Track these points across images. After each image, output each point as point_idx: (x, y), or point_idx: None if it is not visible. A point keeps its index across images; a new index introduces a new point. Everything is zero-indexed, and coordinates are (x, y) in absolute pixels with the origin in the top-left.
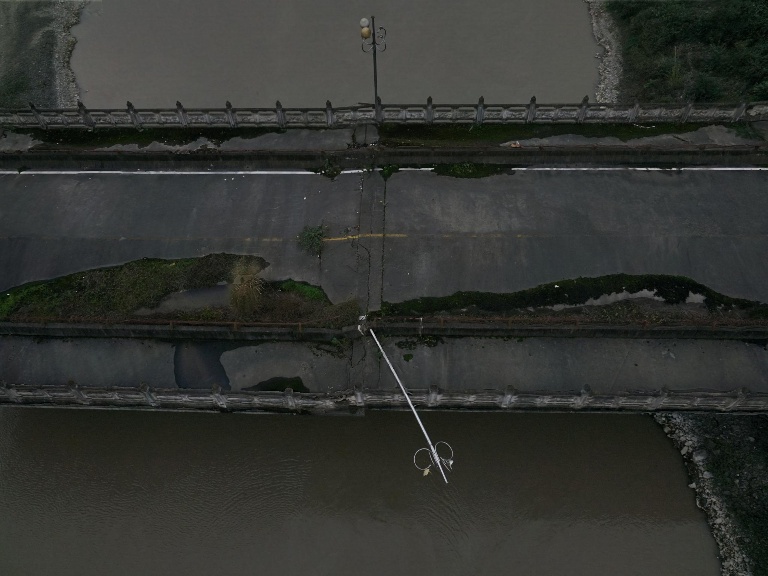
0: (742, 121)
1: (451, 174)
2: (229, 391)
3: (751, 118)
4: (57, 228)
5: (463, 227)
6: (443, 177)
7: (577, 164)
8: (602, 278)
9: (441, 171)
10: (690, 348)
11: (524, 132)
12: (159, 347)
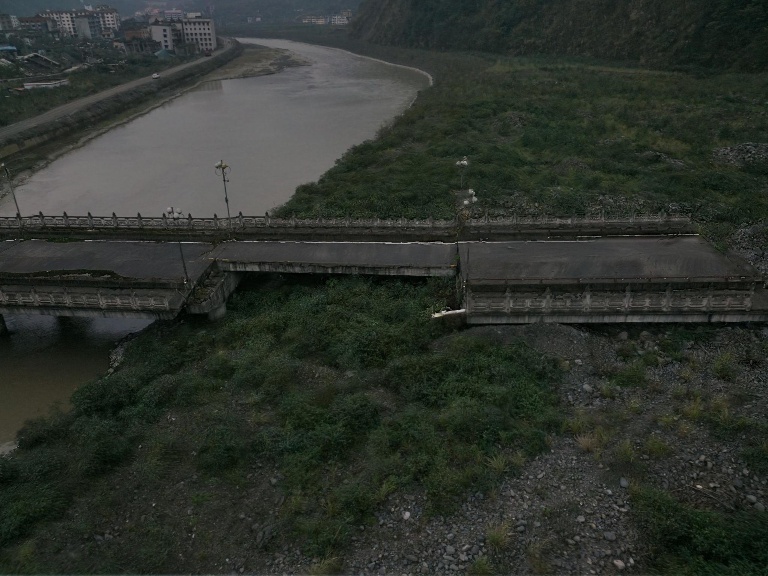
0: (220, 229)
1: (53, 241)
2: None
3: (225, 227)
4: None
5: (33, 255)
6: (48, 242)
7: (118, 240)
8: (73, 270)
9: (50, 240)
10: None
11: None
12: None
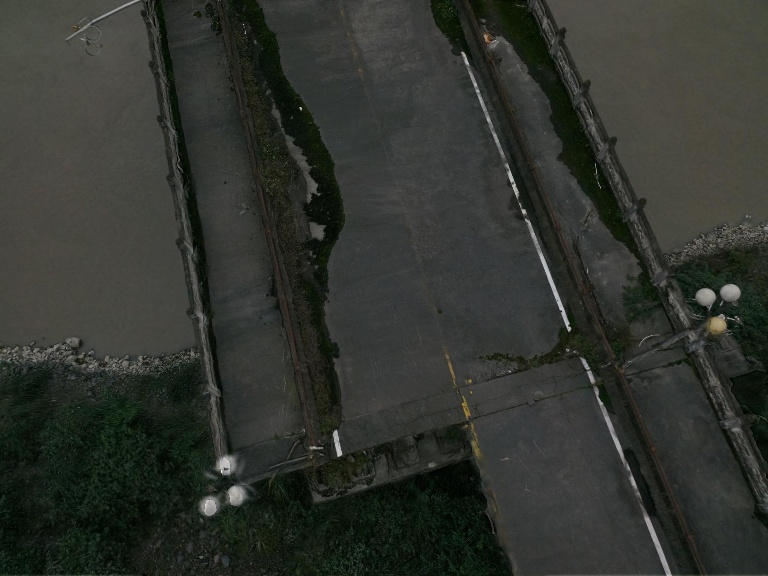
0: (657, 293)
1: (434, 0)
2: None
3: (666, 302)
4: None
5: (358, 23)
6: None
7: (494, 111)
8: (322, 146)
9: None
10: (255, 227)
11: (533, 55)
12: None
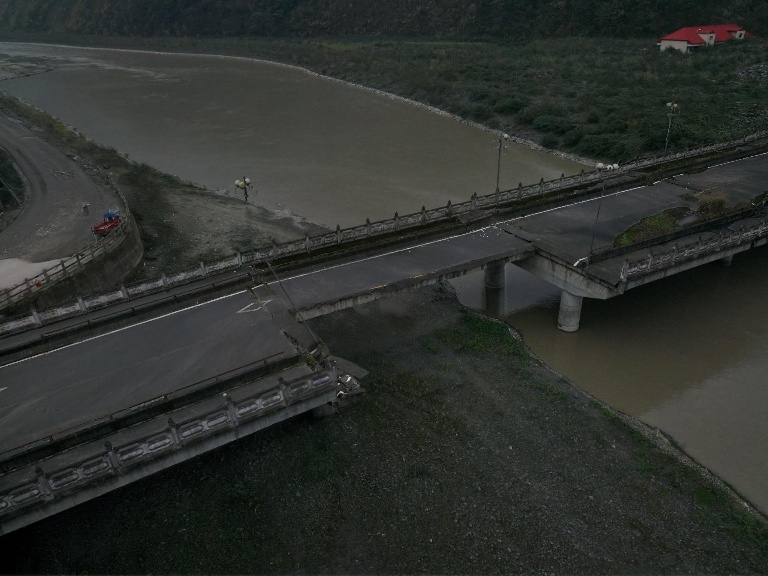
0: None
1: (693, 173)
2: (766, 221)
3: (746, 142)
4: (588, 222)
5: None
6: None
7: (723, 162)
8: None
9: (688, 173)
10: None
11: None
12: (705, 233)
